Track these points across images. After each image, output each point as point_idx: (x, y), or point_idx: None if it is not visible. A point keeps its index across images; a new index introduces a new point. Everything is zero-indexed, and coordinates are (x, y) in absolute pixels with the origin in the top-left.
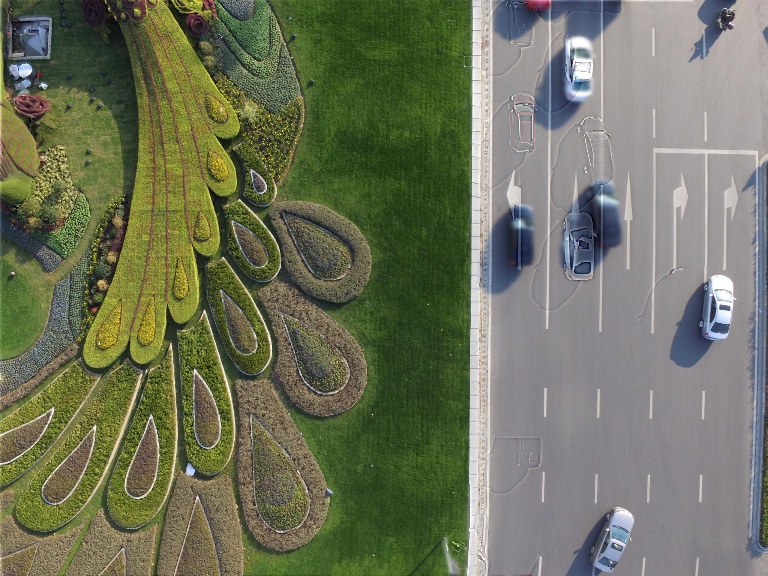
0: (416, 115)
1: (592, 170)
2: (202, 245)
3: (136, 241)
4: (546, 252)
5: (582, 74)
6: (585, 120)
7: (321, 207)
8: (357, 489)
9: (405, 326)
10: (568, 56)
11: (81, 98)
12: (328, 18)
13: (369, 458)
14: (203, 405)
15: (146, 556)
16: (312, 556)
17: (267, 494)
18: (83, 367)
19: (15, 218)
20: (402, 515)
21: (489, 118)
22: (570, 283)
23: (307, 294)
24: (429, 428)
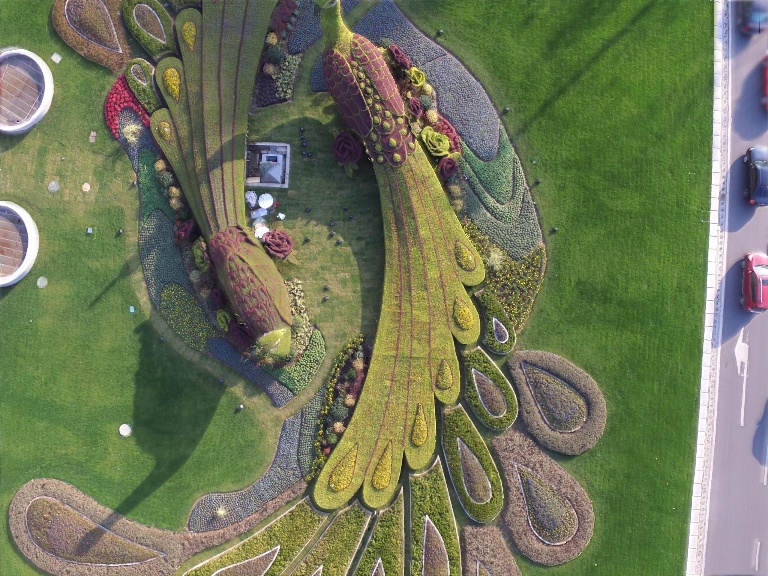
0: (654, 269)
1: None
2: (443, 393)
3: (377, 386)
4: None
5: None
6: None
7: (560, 359)
8: None
9: (633, 479)
10: None
11: (320, 231)
12: (572, 165)
13: None
14: (434, 552)
15: None
16: None
17: None
18: (311, 506)
19: (253, 354)
20: None
21: (721, 273)
22: None
23: (541, 445)
24: None
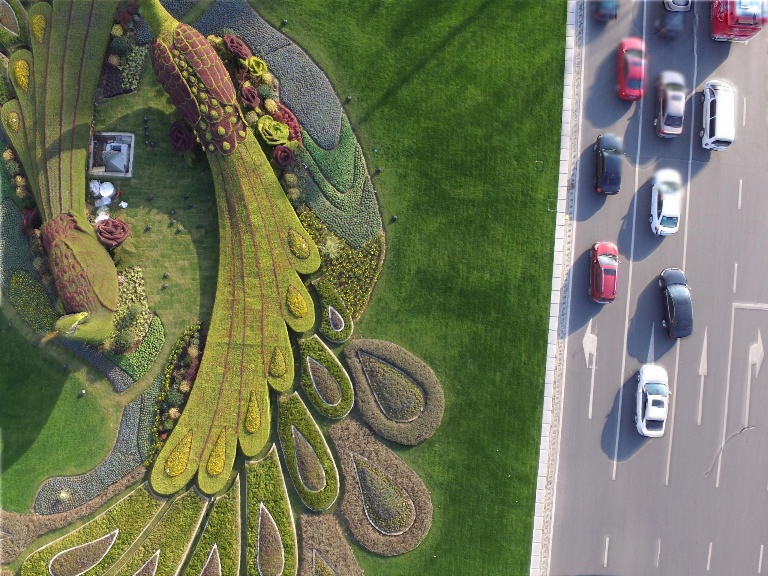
0: (497, 258)
1: (671, 325)
2: (277, 380)
3: (211, 372)
4: (618, 403)
5: (669, 230)
6: (666, 271)
7: (397, 348)
8: None
9: (473, 471)
10: (655, 207)
11: (161, 219)
12: (414, 153)
13: None
14: (268, 539)
15: None
16: None
17: None
18: (149, 491)
19: (90, 340)
20: None
21: (570, 263)
22: (641, 437)
23: (378, 434)
24: (490, 572)
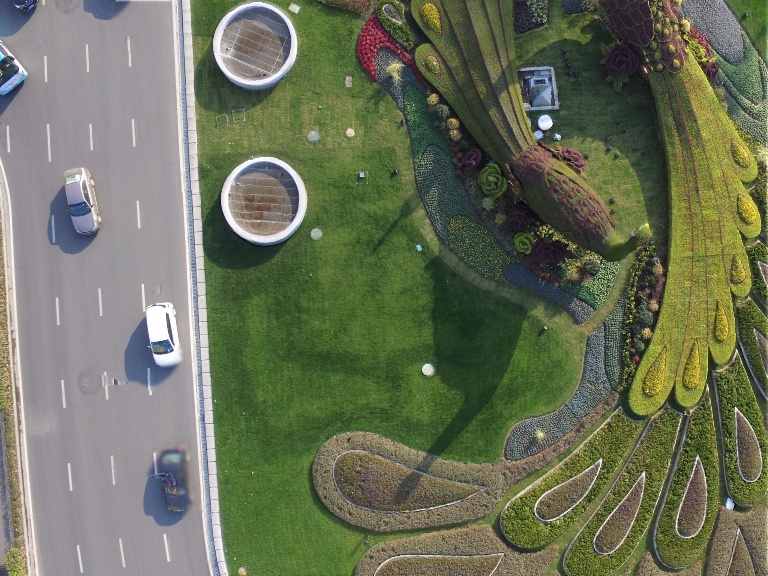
0: None
1: None
2: (738, 287)
3: (678, 288)
4: None
5: None
6: None
7: None
8: None
9: None
10: None
11: (597, 148)
12: None
13: None
14: (748, 441)
15: None
16: None
17: None
18: (625, 415)
19: (558, 273)
20: None
21: None
22: None
23: None
24: None
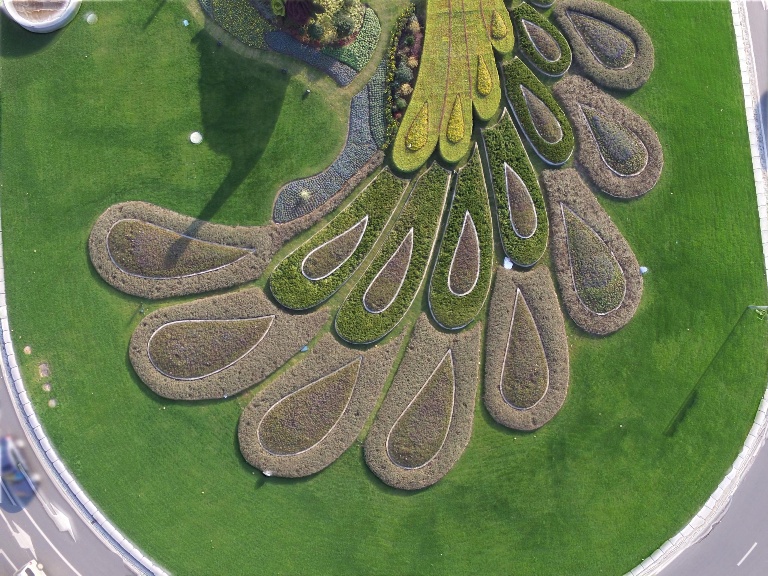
0: None
1: None
2: (500, 42)
3: (436, 43)
4: None
5: None
6: None
7: (601, 3)
8: (666, 266)
9: (689, 108)
10: None
11: None
12: None
13: (673, 235)
14: (518, 195)
15: (474, 354)
16: (631, 337)
17: (587, 277)
18: (392, 173)
19: (313, 32)
20: (709, 288)
21: None
22: None
23: (599, 84)
24: (723, 203)
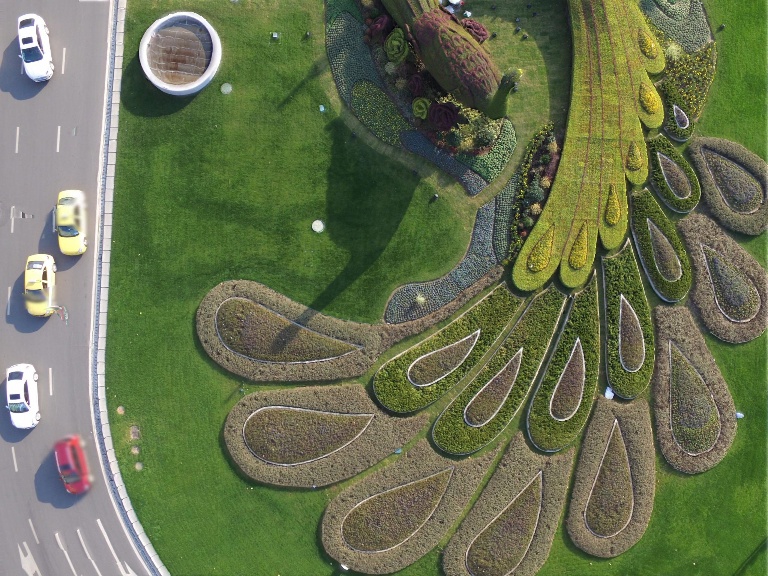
0: None
1: None
2: (633, 174)
3: (571, 167)
4: None
5: None
6: None
7: (736, 144)
8: (761, 414)
9: None
10: None
11: (505, 27)
12: None
13: None
14: (631, 329)
15: (564, 479)
16: (717, 479)
17: (684, 417)
18: (508, 290)
19: (451, 139)
20: None
21: None
22: None
23: (723, 226)
24: None
